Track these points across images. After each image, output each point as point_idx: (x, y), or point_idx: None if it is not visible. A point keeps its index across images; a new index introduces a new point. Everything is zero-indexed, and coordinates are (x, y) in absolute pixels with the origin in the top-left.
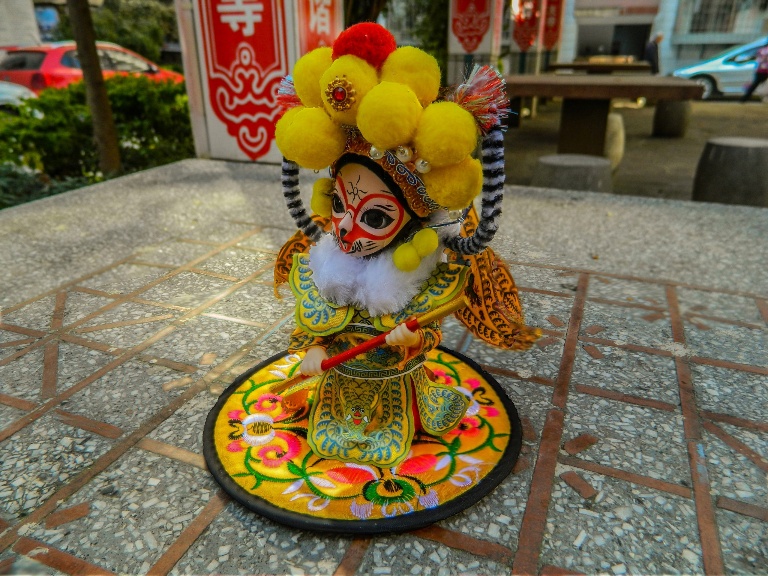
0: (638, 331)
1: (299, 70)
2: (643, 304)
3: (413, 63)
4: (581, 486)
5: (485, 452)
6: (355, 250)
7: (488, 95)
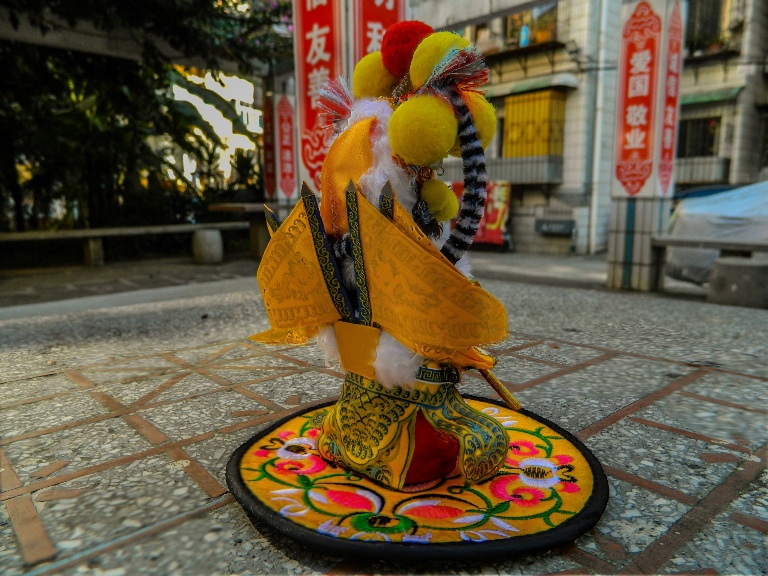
0: None
1: None
2: None
3: None
4: None
5: None
6: None
7: None
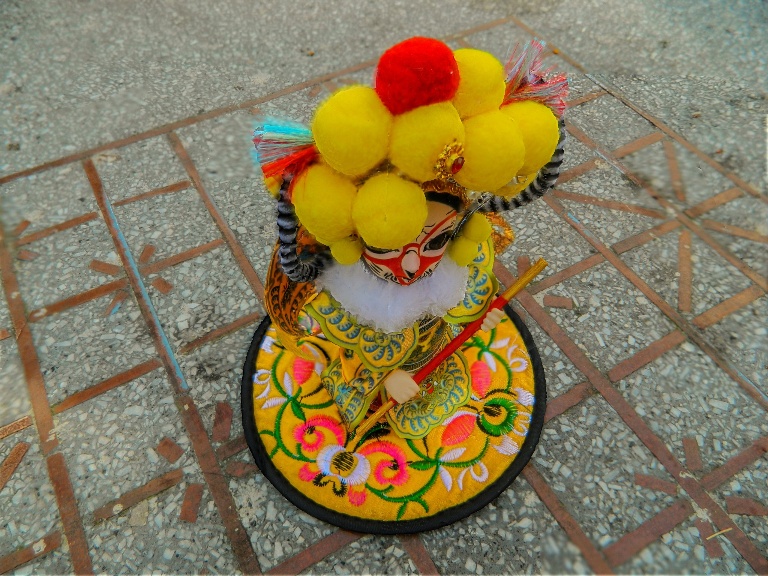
0: None
1: (356, 145)
2: None
3: (498, 81)
4: (561, 302)
5: (502, 329)
6: (421, 278)
7: (562, 81)
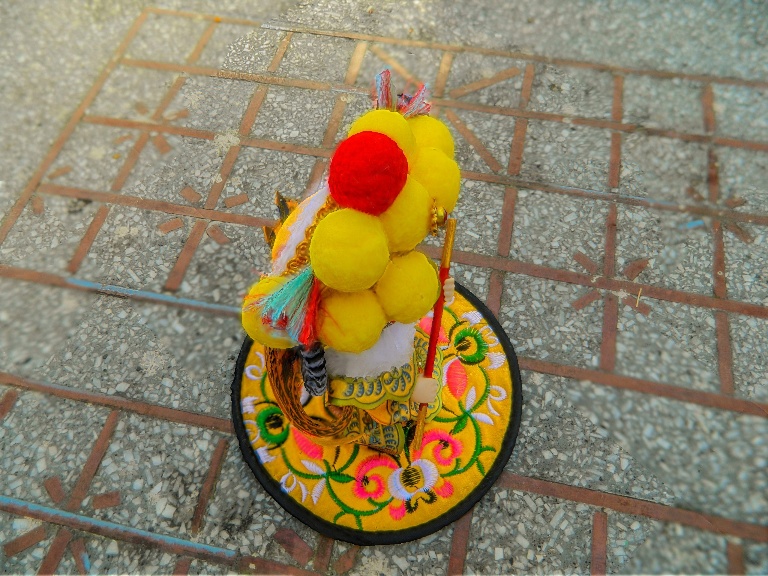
0: (193, 161)
1: (380, 264)
2: (131, 147)
3: None
4: None
5: None
6: None
7: None
